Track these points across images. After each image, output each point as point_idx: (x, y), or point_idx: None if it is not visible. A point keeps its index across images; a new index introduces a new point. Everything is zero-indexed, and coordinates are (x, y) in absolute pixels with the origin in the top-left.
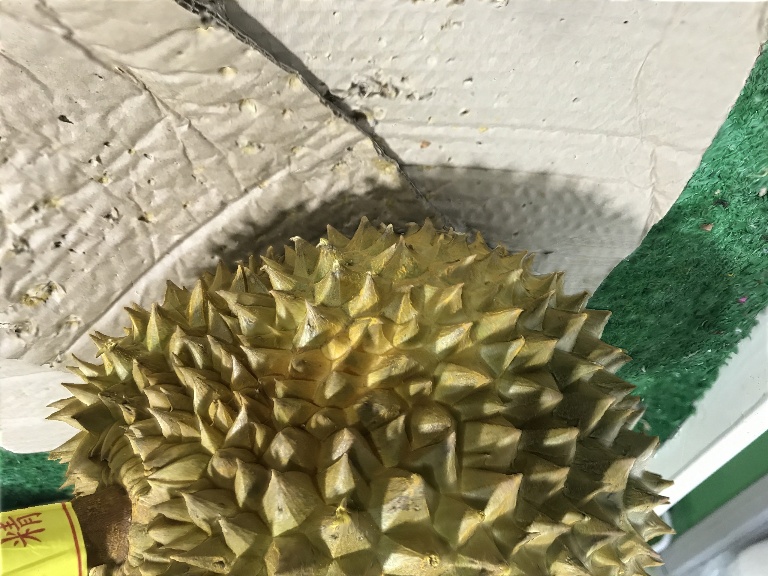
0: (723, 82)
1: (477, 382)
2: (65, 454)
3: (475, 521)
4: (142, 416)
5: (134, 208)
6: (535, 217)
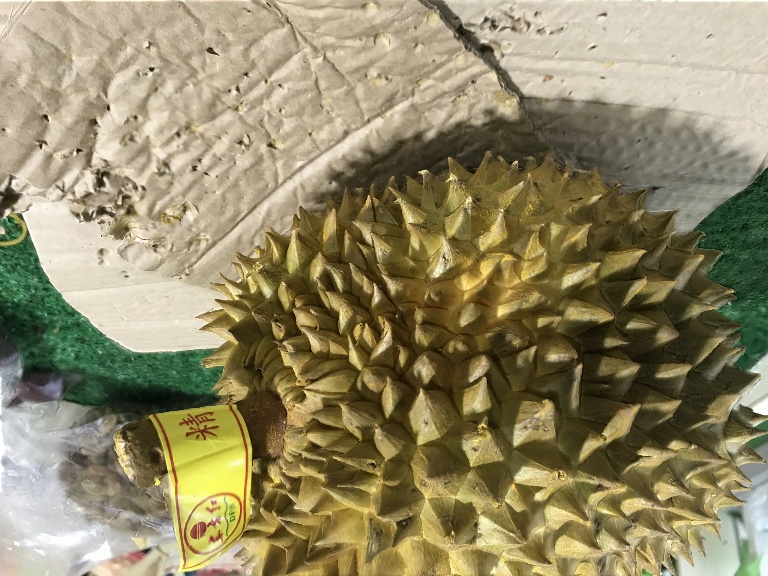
0: None
1: (601, 318)
2: (216, 361)
3: (597, 443)
4: (289, 333)
5: (264, 135)
6: (648, 152)
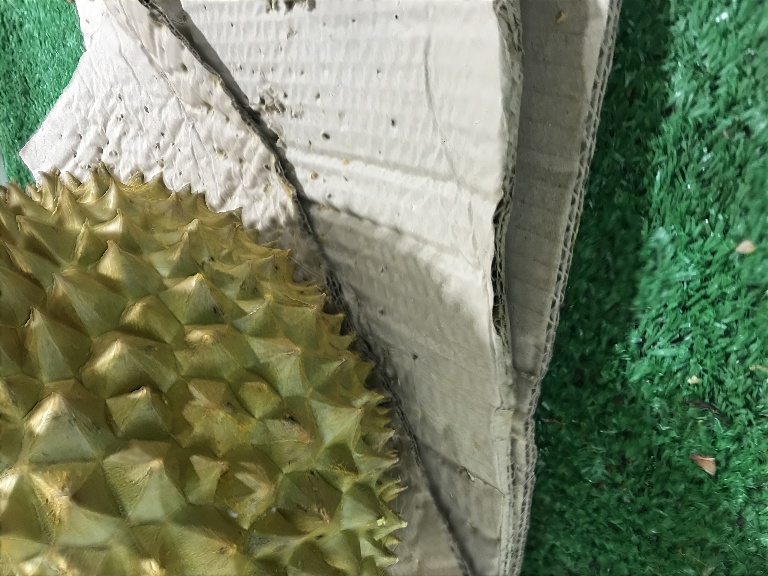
0: (486, 82)
1: None
2: None
3: None
4: None
5: None
6: (392, 290)
